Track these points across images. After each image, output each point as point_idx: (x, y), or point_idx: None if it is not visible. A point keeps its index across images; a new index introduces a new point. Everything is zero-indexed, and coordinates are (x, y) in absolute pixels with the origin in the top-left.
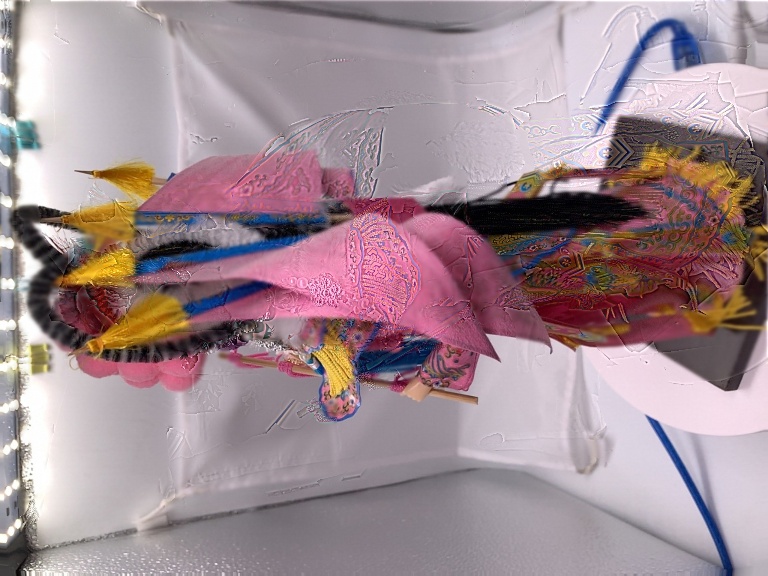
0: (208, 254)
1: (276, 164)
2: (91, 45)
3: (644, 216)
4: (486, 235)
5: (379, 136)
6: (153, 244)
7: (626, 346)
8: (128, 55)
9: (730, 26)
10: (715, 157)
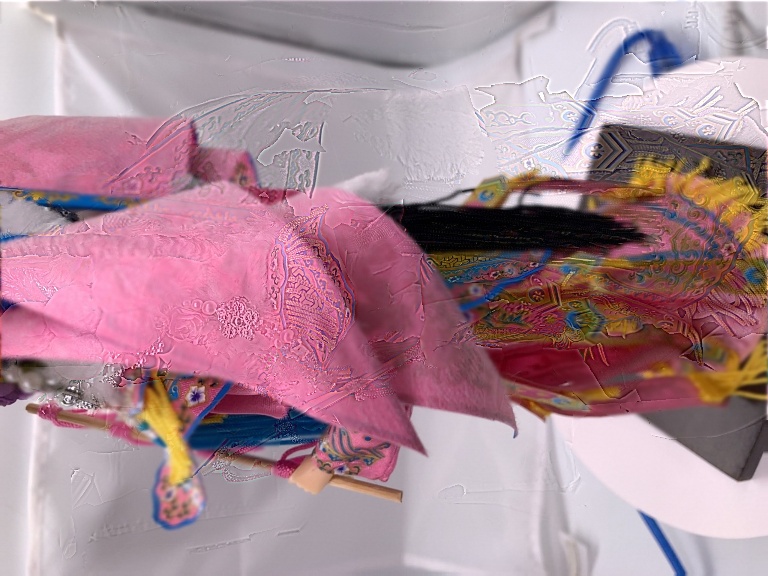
0: (84, 266)
1: (174, 154)
2: (13, 25)
3: (640, 239)
4: None
5: (318, 132)
6: None
7: (605, 392)
8: (57, 40)
9: (723, 46)
10: (733, 166)
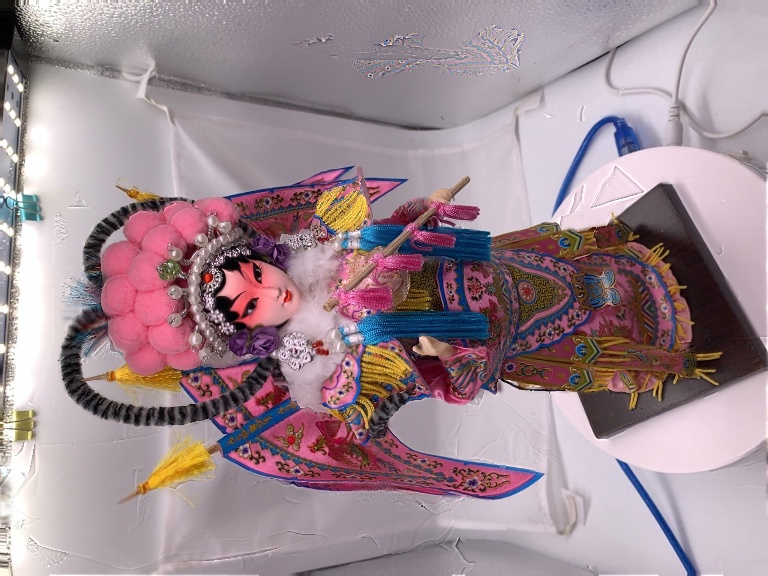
0: None
1: None
2: None
3: None
4: None
5: None
6: (126, 210)
7: (753, 368)
8: (133, 575)
9: None
10: None
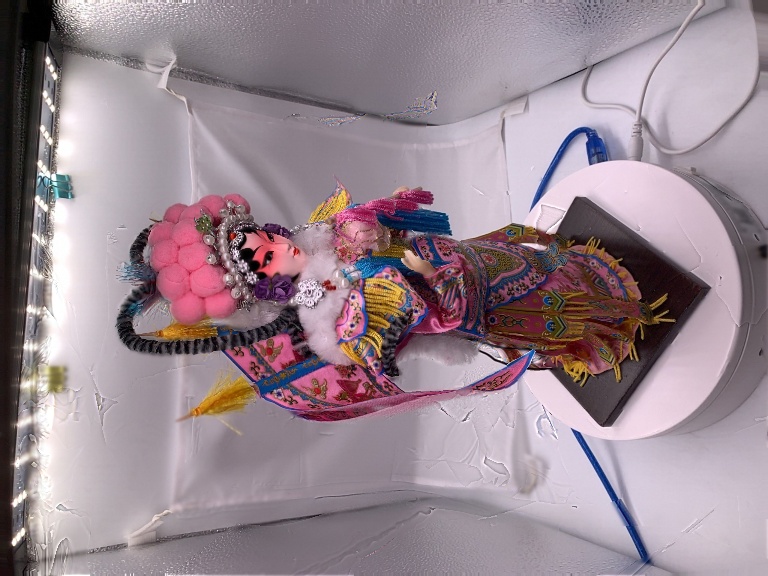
0: None
1: None
2: None
3: None
4: None
5: None
6: None
7: (694, 293)
8: None
9: None
10: None
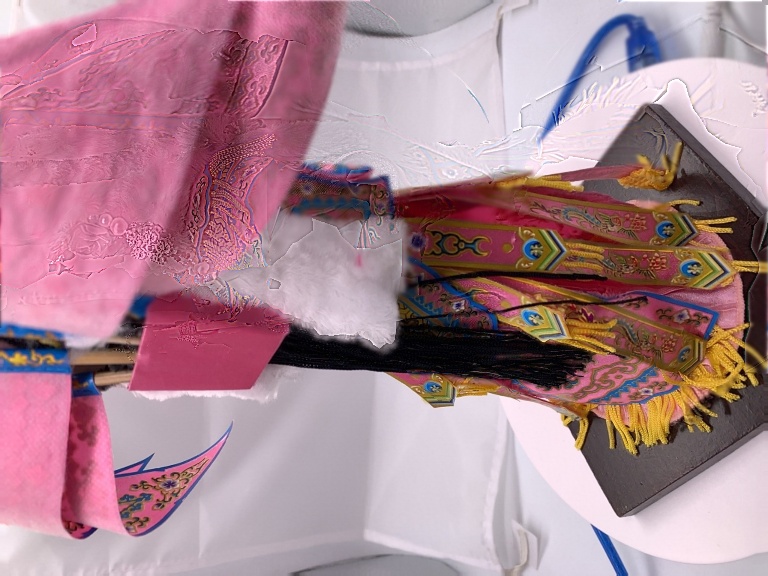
0: None
1: (78, 76)
2: None
3: None
4: (386, 233)
5: None
6: None
7: None
8: None
9: None
10: (690, 333)
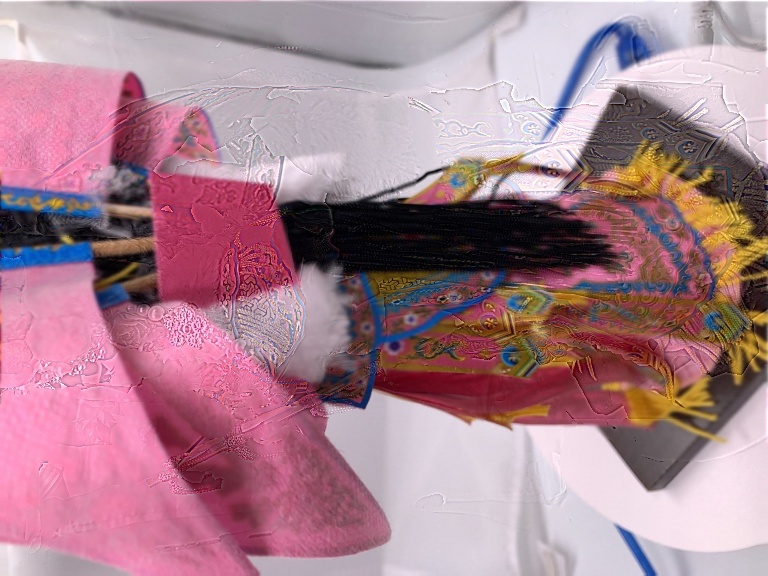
0: (20, 266)
1: (116, 151)
2: None
3: (606, 265)
4: None
5: None
6: None
7: (592, 407)
8: (42, 20)
9: (737, 48)
10: (712, 189)
